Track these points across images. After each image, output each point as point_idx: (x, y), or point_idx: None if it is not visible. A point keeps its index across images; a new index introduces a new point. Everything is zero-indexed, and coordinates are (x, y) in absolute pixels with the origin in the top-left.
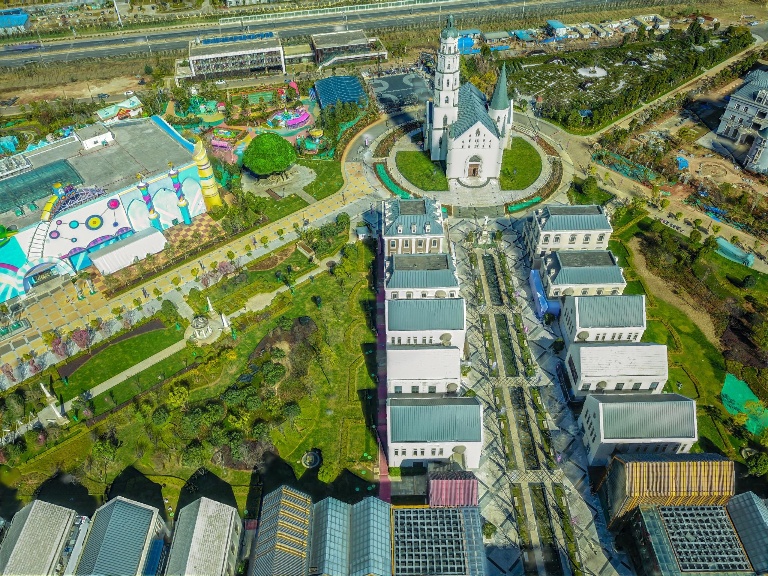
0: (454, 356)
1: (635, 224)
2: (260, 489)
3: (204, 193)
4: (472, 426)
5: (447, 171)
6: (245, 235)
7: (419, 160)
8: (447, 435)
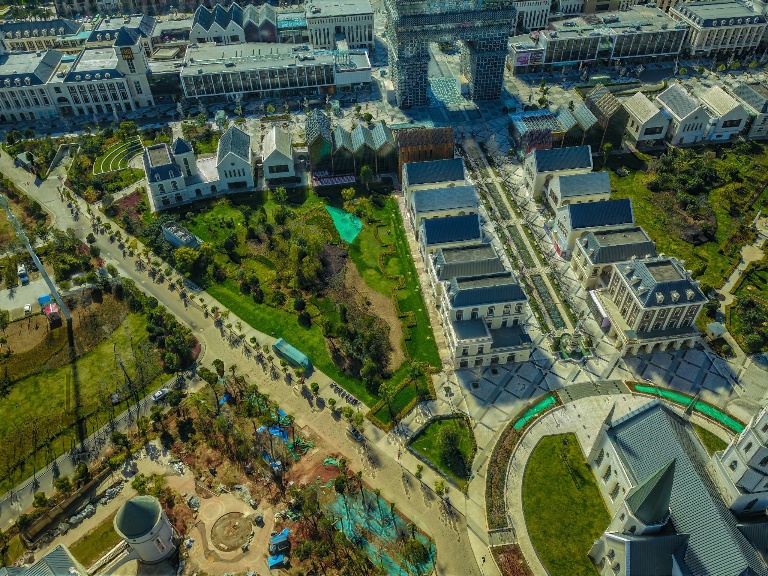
0: None
1: None
2: (641, 159)
3: None
4: None
5: None
6: None
7: None
8: None
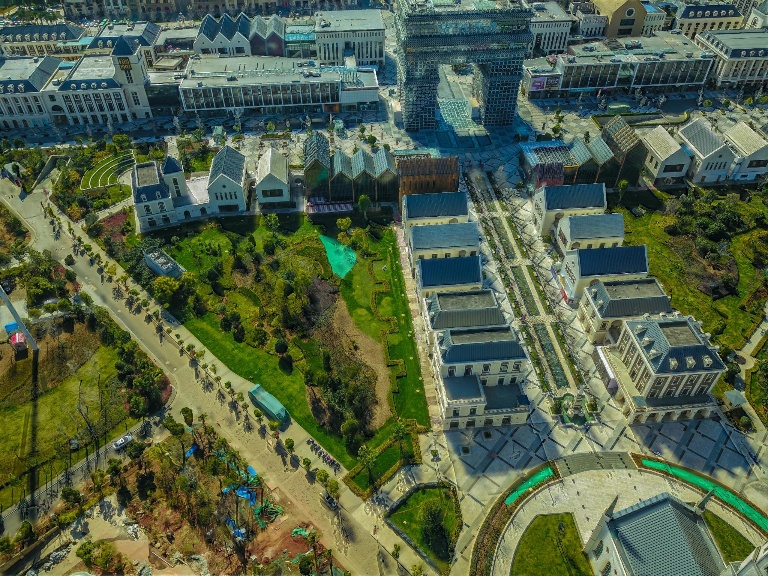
0: None
1: None
2: (659, 198)
3: None
4: None
5: None
6: None
7: None
8: None
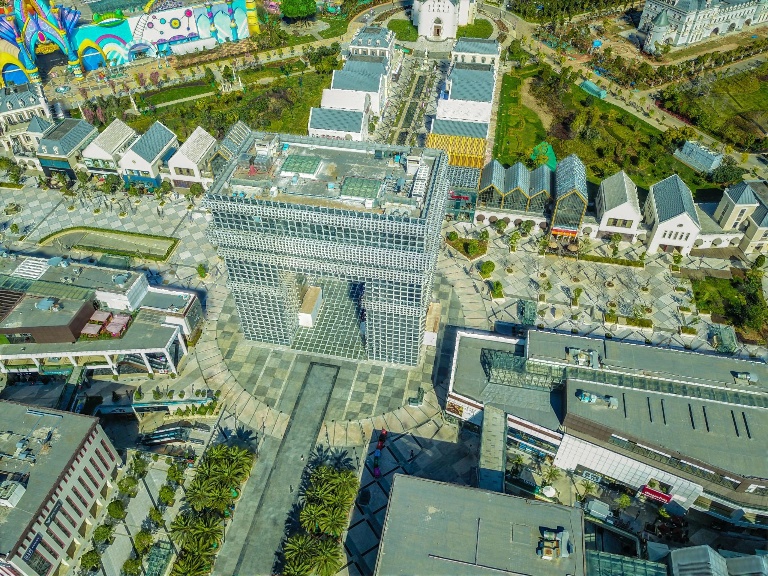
0: (362, 96)
1: (537, 71)
2: None
3: (249, 22)
4: (357, 124)
5: (418, 29)
6: (270, 51)
7: (404, 25)
8: (342, 127)
